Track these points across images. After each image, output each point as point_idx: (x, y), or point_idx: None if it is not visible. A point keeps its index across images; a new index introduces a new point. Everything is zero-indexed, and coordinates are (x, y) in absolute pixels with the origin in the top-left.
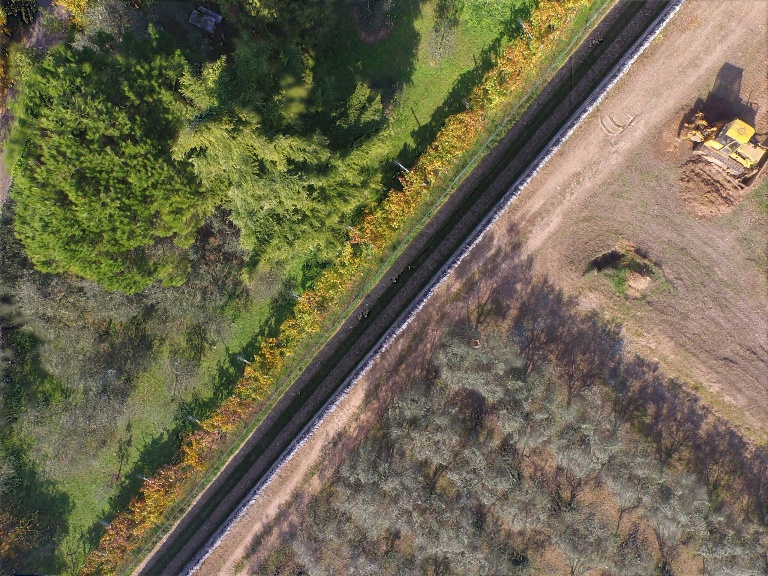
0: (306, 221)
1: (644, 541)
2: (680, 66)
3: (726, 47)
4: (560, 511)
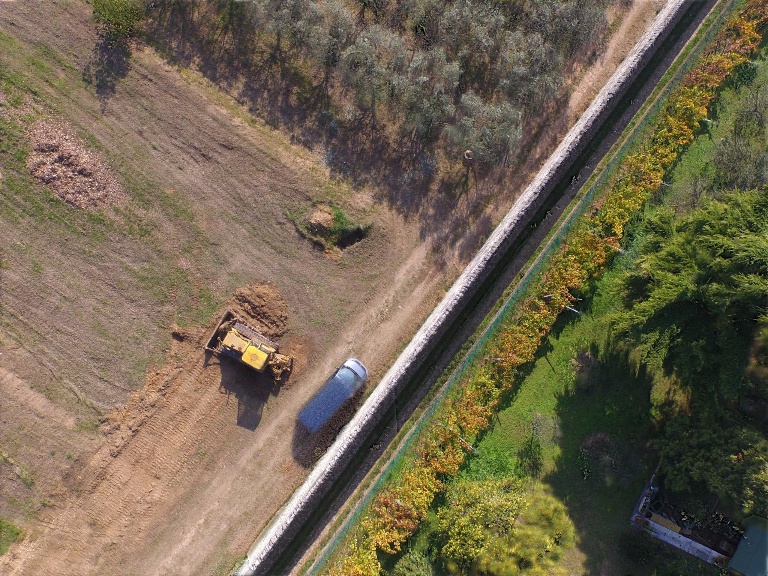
0: (719, 229)
1: None
2: (296, 427)
3: (254, 446)
4: None
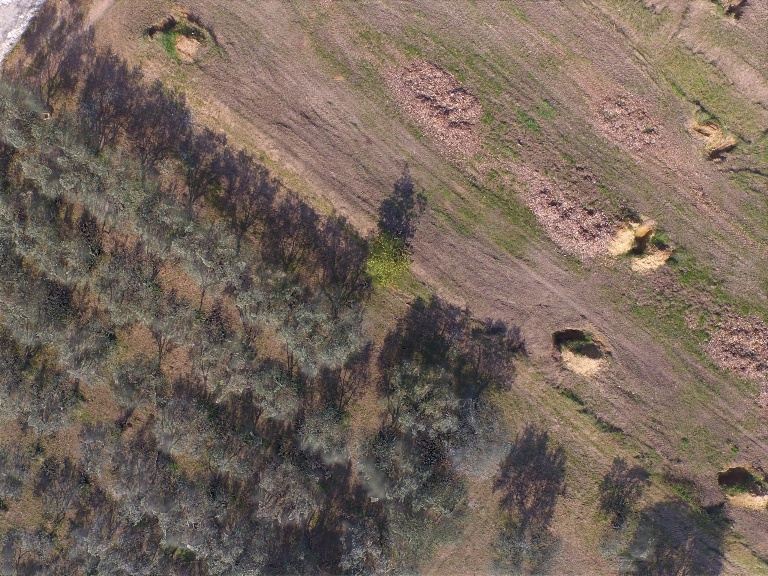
0: None
1: (228, 318)
2: None
3: None
4: (142, 287)
